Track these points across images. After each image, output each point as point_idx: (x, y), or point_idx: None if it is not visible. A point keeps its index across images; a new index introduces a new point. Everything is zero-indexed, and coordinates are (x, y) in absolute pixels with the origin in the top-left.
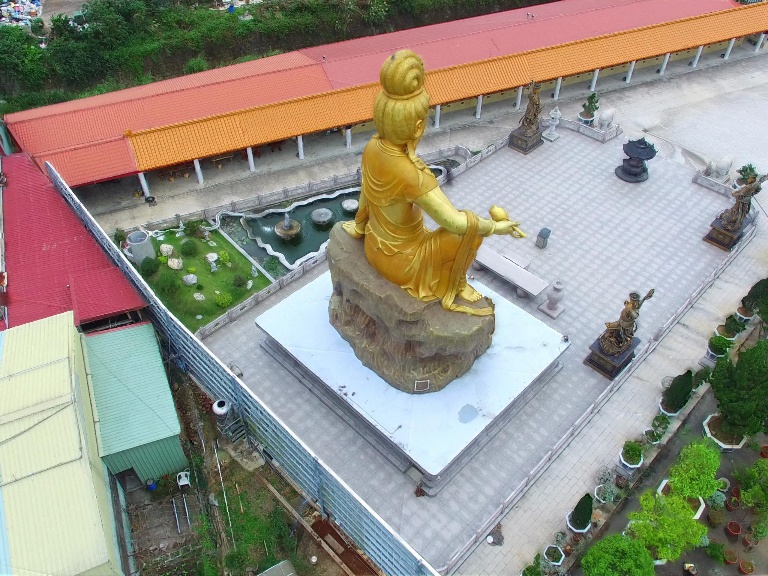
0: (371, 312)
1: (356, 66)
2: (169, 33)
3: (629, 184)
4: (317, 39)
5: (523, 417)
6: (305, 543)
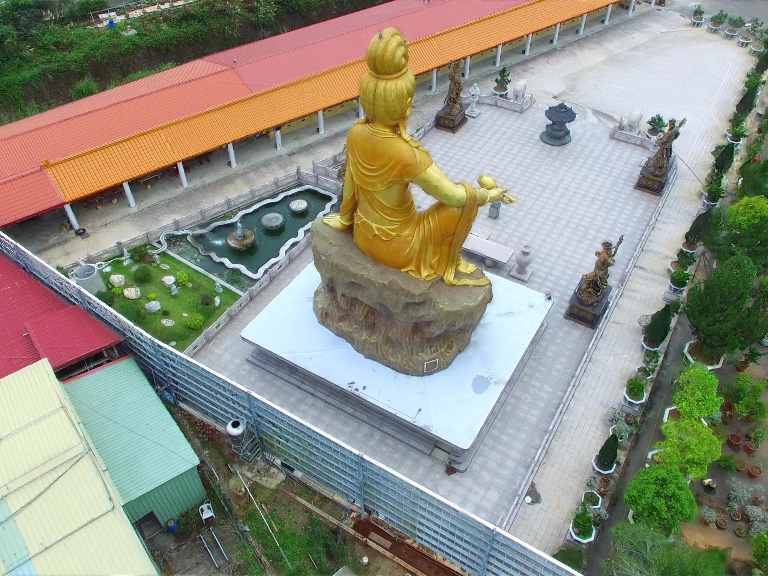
0: (373, 301)
1: (270, 67)
2: (47, 57)
3: (556, 148)
4: (208, 47)
5: (525, 379)
6: (351, 546)
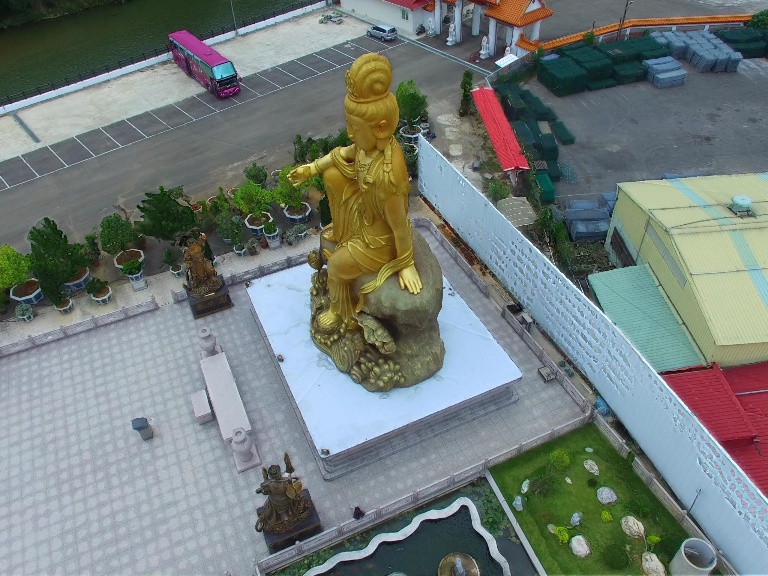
0: None
1: None
2: None
3: None
4: None
5: None
6: None
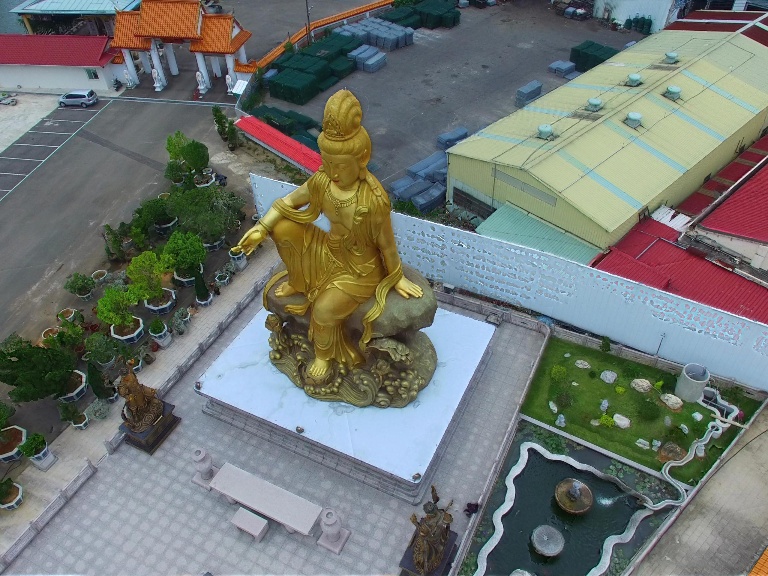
0: None
1: None
2: None
3: None
4: None
5: None
6: None
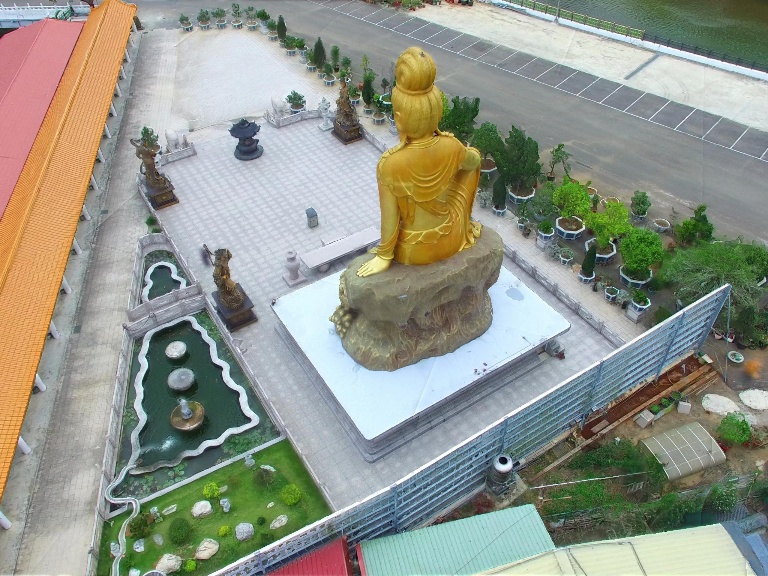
0: None
1: None
2: None
3: (261, 158)
4: None
5: None
6: None
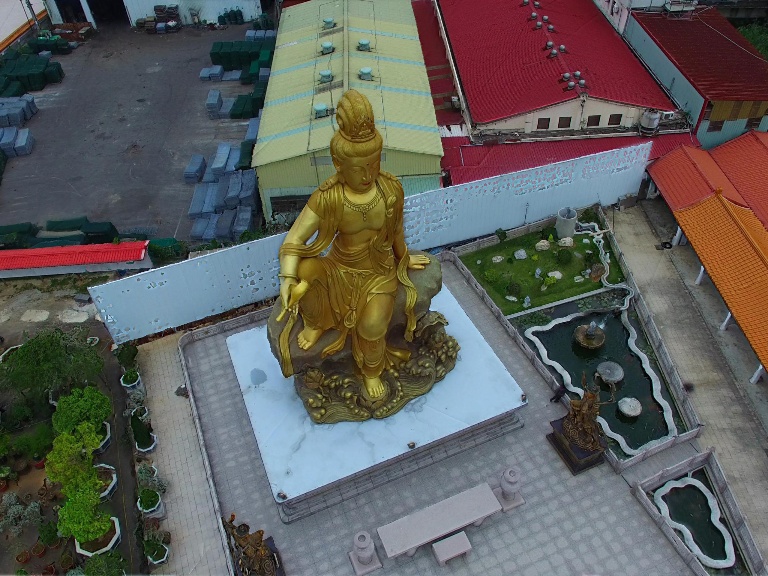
0: None
1: None
2: None
3: None
4: None
5: (255, 454)
6: None
